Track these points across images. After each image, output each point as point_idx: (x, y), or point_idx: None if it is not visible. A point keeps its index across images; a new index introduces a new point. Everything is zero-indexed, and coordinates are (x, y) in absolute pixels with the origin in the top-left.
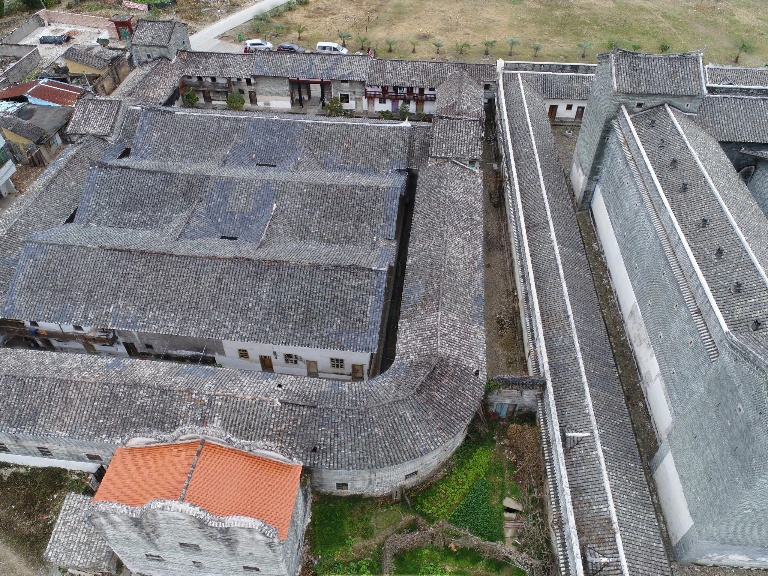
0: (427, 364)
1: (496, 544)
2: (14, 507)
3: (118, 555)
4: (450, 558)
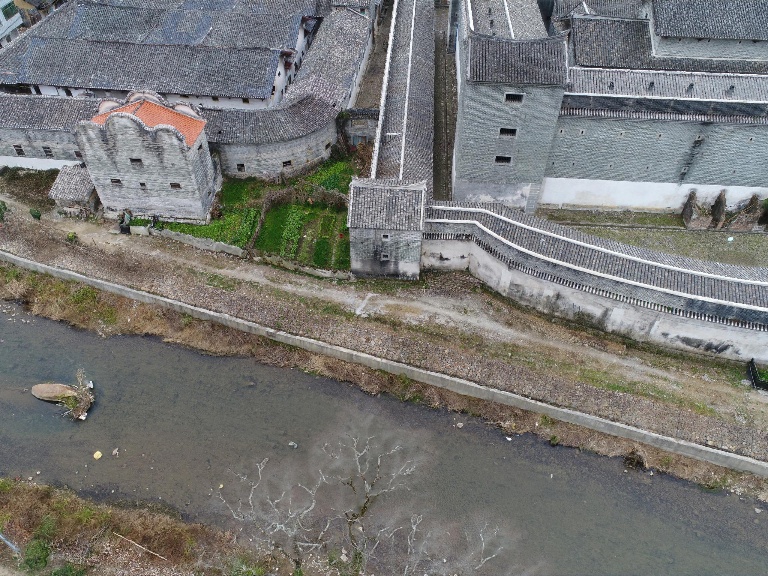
0: (300, 97)
1: (334, 190)
2: (28, 188)
3: (94, 184)
4: (308, 208)
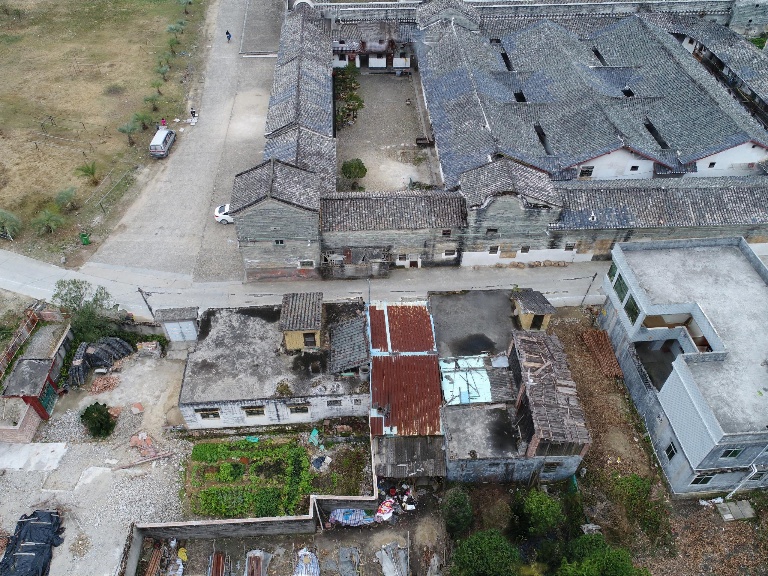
0: (675, 17)
1: None
2: None
3: None
4: None
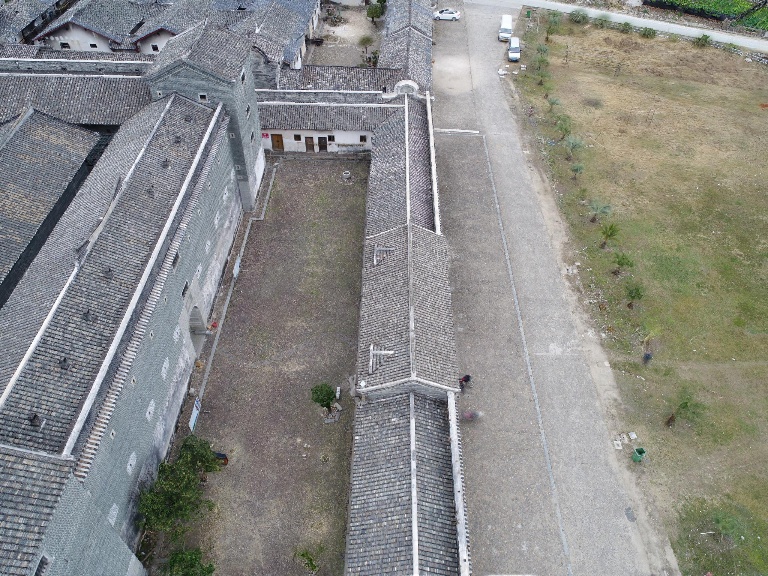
0: (3, 43)
1: None
2: None
3: None
4: None
